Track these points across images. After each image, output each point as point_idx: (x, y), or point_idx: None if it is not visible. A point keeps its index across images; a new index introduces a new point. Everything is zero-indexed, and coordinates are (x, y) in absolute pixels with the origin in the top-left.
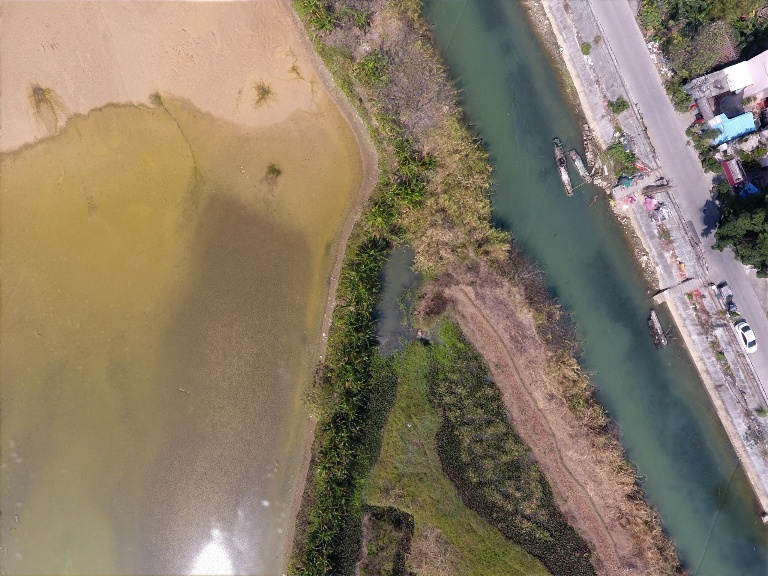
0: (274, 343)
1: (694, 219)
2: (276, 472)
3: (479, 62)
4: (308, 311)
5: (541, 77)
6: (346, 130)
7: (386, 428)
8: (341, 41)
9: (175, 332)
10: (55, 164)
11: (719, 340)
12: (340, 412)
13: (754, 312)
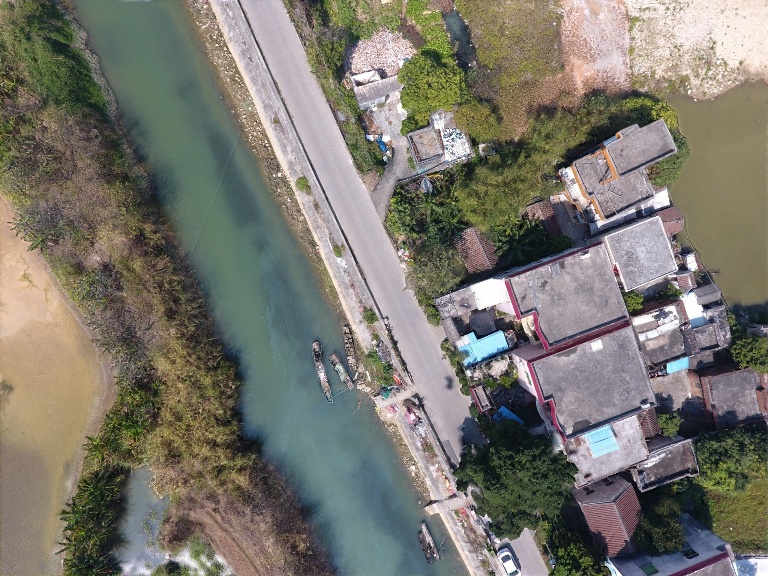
0: (9, 572)
1: (452, 438)
2: None
3: (230, 262)
4: (46, 536)
5: (299, 275)
6: (85, 340)
7: None
8: (70, 250)
9: None
10: None
11: (489, 559)
12: None
13: (520, 535)
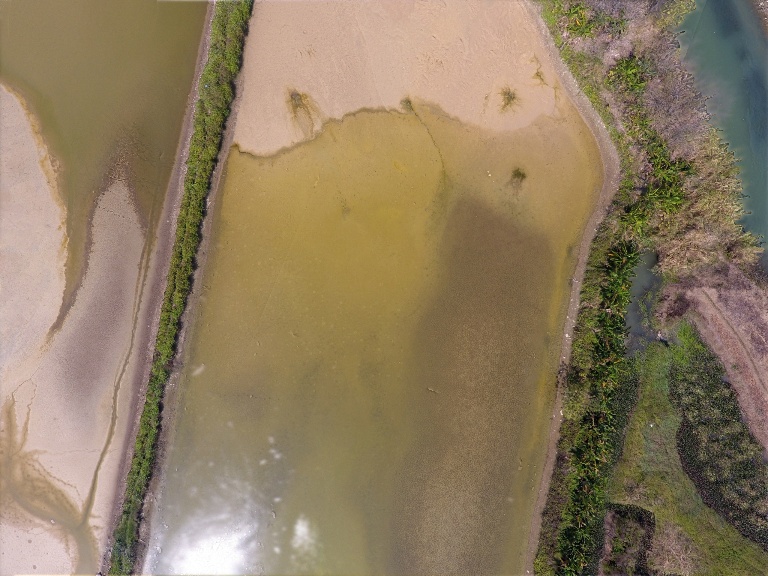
0: (518, 344)
1: None
2: (520, 470)
3: (715, 68)
4: (551, 312)
5: None
6: (587, 135)
7: (628, 428)
8: (589, 48)
9: (424, 333)
10: (311, 168)
11: None
12: (599, 412)
13: None
